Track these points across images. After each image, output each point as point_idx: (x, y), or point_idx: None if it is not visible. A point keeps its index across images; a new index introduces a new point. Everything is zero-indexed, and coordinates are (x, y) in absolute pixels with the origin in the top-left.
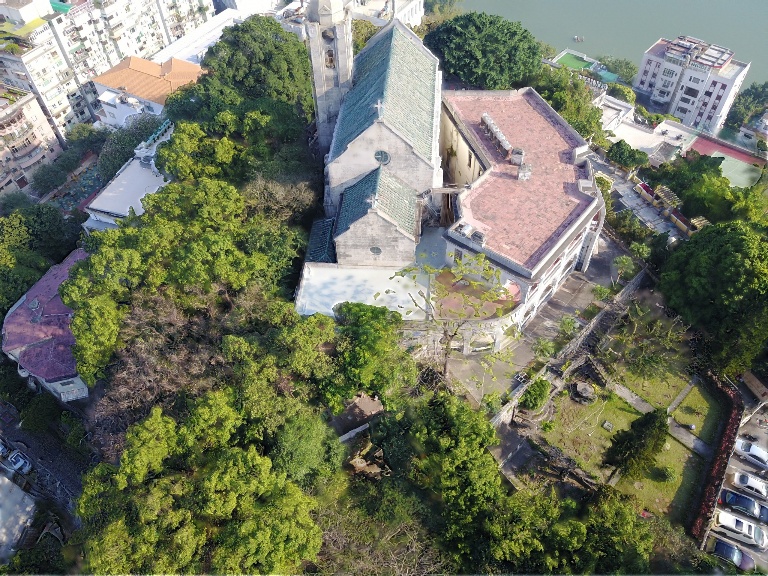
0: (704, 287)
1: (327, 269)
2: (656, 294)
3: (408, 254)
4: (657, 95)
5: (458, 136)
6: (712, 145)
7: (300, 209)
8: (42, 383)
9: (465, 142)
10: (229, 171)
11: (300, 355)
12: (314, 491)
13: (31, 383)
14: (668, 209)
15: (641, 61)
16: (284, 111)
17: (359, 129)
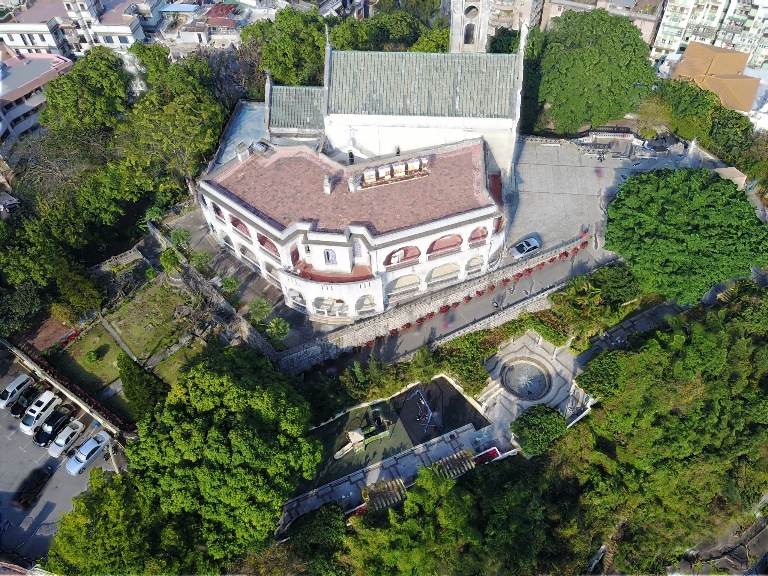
0: None
1: None
2: None
3: None
4: None
5: None
6: None
7: None
8: None
9: None
10: None
11: None
12: None
13: None
14: None
15: None
16: None
17: None
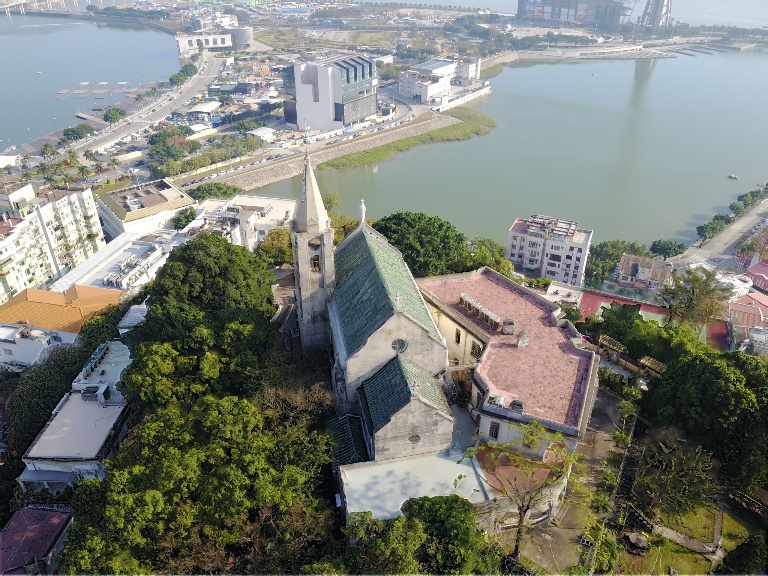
0: (701, 416)
1: (363, 469)
2: (647, 432)
3: (446, 436)
4: (528, 263)
5: (440, 317)
6: (597, 297)
7: (319, 411)
8: None
9: (453, 321)
10: (216, 386)
11: (402, 568)
12: None
13: None
14: (615, 354)
15: (508, 238)
16: (257, 318)
17: (371, 322)
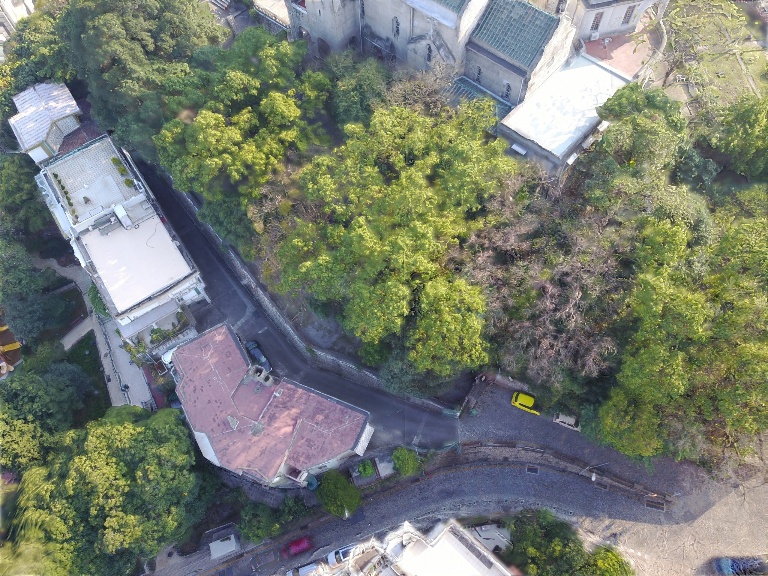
0: None
1: (515, 115)
2: None
3: (568, 47)
4: None
5: None
6: None
7: (449, 84)
8: (317, 471)
9: None
10: (301, 124)
11: None
12: None
13: (303, 485)
14: None
15: None
16: None
17: None
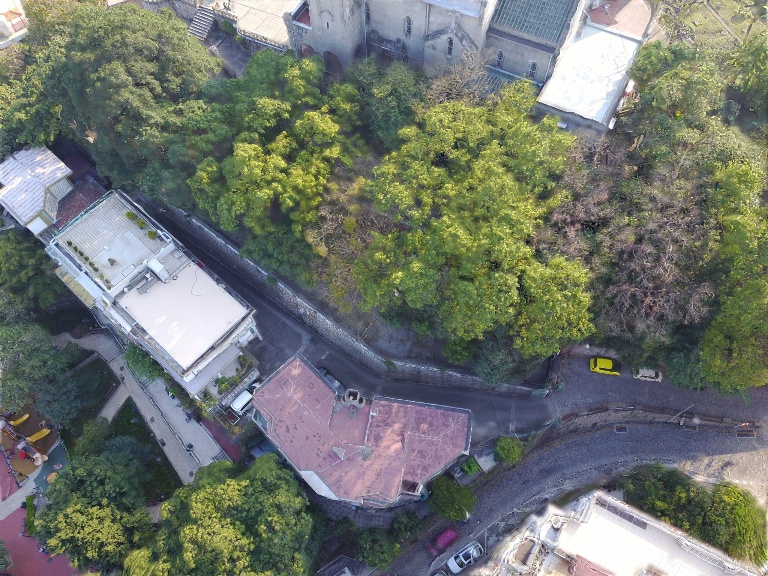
0: None
1: (545, 91)
2: None
3: (579, 18)
4: None
5: None
6: None
7: (482, 73)
8: None
9: None
10: (340, 139)
11: None
12: (766, 173)
13: (417, 498)
14: None
15: None
16: None
17: None
